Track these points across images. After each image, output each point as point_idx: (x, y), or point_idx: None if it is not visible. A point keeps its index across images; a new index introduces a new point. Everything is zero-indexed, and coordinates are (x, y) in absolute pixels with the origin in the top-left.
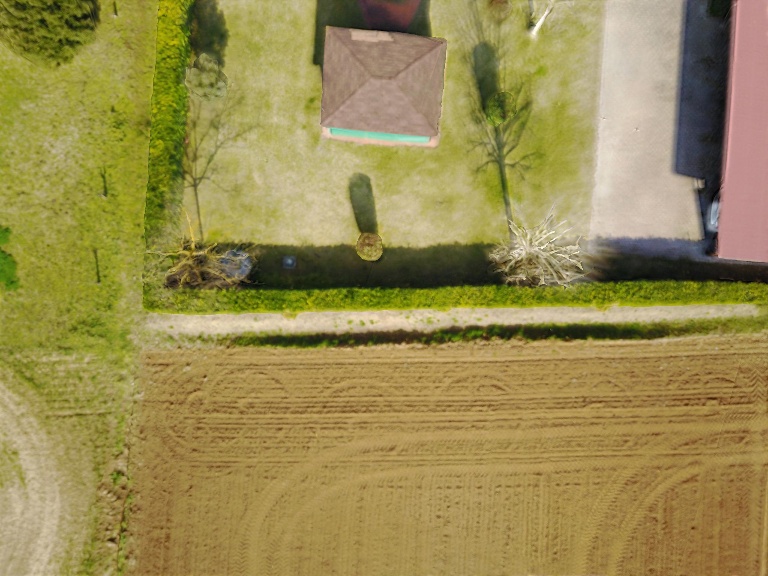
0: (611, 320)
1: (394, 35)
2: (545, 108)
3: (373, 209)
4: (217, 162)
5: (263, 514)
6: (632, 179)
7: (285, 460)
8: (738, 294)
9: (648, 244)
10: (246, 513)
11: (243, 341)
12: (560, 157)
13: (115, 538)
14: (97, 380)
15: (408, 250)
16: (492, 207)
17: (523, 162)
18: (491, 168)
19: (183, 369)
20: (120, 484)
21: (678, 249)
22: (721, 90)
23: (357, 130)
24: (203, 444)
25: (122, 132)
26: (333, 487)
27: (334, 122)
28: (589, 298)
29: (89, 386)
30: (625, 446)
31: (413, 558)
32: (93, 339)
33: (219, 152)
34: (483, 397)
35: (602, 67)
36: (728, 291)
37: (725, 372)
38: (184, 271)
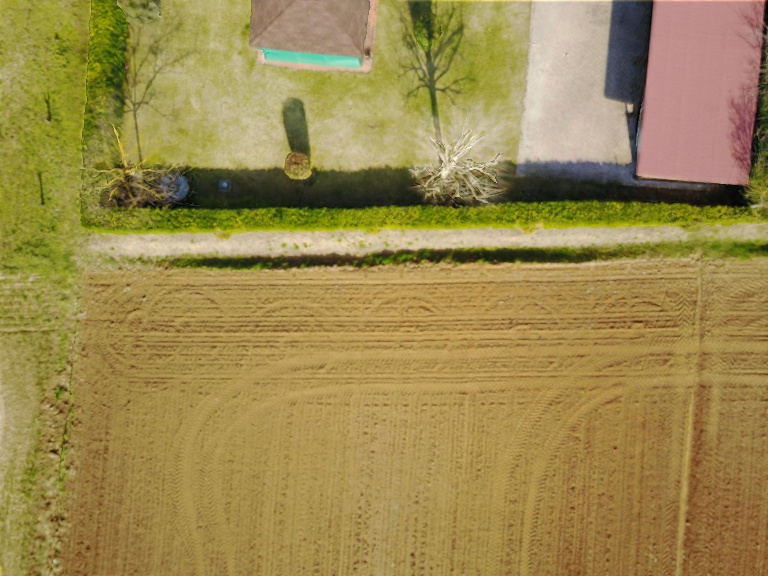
0: (540, 245)
1: None
2: (475, 34)
3: (306, 133)
4: (155, 87)
5: (197, 428)
6: (561, 104)
7: (219, 377)
8: (660, 215)
9: (576, 168)
10: (181, 427)
11: (181, 263)
12: (490, 82)
13: (58, 450)
14: (41, 299)
15: (340, 174)
16: (422, 132)
17: (453, 87)
18: (421, 93)
19: (123, 289)
20: (63, 399)
21: (606, 173)
22: (648, 12)
23: (284, 50)
24: (141, 361)
25: (65, 59)
26: (265, 403)
27: (261, 42)
28: (512, 218)
29: (33, 304)
30: (550, 367)
31: (341, 473)
32: (37, 259)
33: (157, 77)
34: (412, 318)
35: None
36: (651, 212)
37: (652, 296)
38: (114, 185)
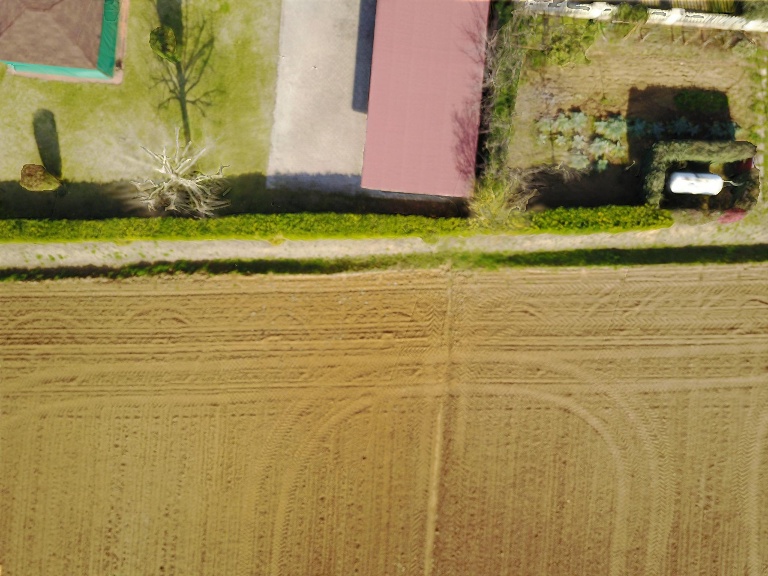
0: (295, 256)
1: None
2: (225, 46)
3: (56, 144)
4: None
5: None
6: (310, 116)
7: None
8: (396, 226)
9: (325, 180)
10: None
11: None
12: (240, 94)
13: None
14: None
15: (91, 185)
16: (173, 143)
17: (203, 99)
18: (172, 105)
19: None
20: None
21: (354, 185)
22: None
23: (15, 62)
24: None
25: None
26: (14, 416)
27: None
28: (251, 230)
29: None
30: (301, 378)
31: (92, 486)
32: None
33: None
34: (164, 330)
35: (282, 6)
36: (387, 224)
37: (403, 307)
38: None
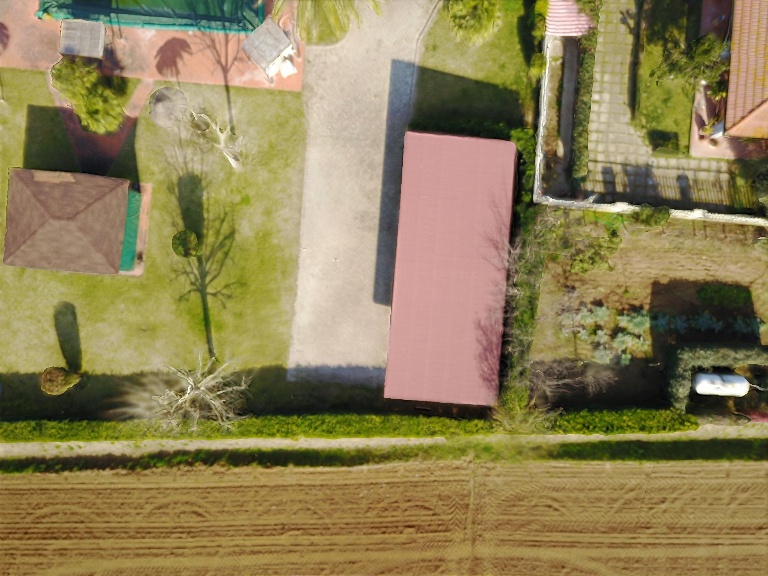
0: (316, 446)
1: (76, 176)
2: (247, 238)
3: (77, 337)
4: None
5: None
6: (331, 308)
7: None
8: (419, 428)
9: (346, 373)
10: None
11: None
12: (261, 286)
13: None
14: None
15: (111, 377)
16: (194, 335)
17: (224, 291)
18: (193, 297)
19: None
20: None
21: (376, 378)
22: None
23: (38, 268)
24: None
25: None
26: None
27: (15, 261)
28: (272, 432)
29: None
30: (322, 574)
31: None
32: None
33: None
34: (184, 524)
35: (303, 198)
36: (410, 425)
37: (425, 499)
38: None
